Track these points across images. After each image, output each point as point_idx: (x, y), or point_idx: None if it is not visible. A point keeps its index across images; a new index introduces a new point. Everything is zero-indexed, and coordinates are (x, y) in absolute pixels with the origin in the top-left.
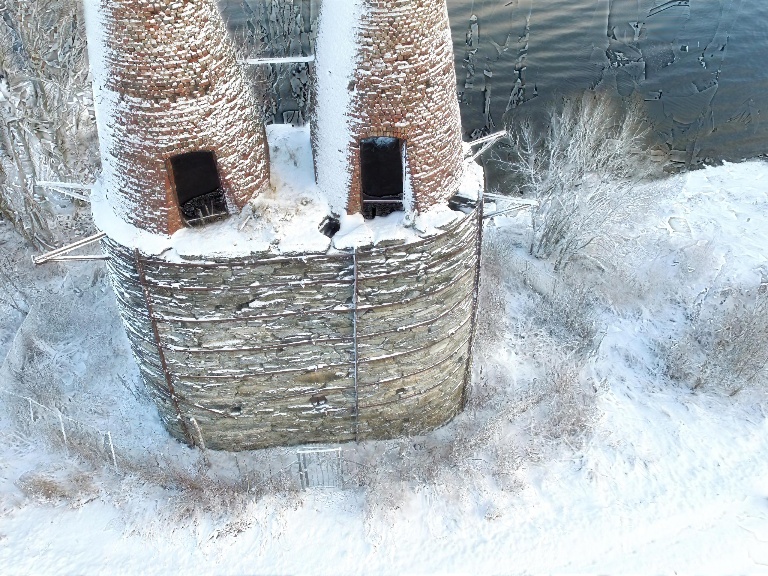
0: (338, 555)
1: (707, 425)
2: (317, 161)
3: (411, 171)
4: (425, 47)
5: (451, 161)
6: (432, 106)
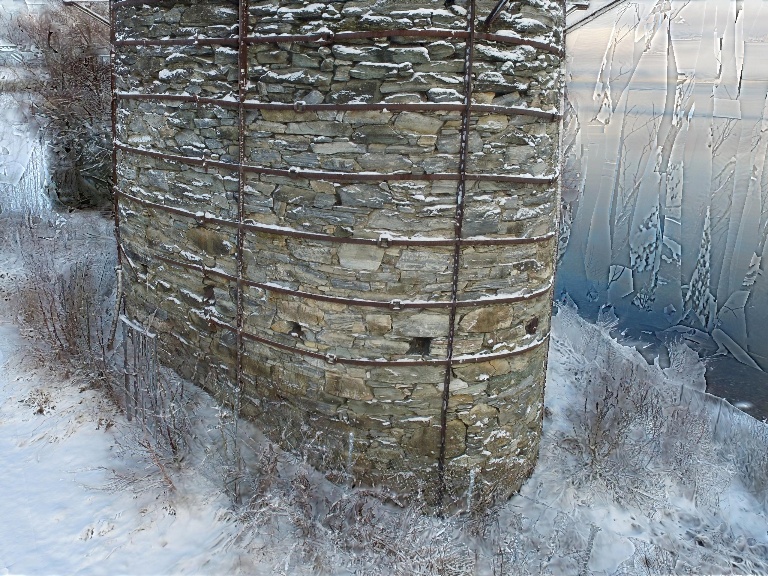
0: (55, 505)
1: None
2: None
3: None
4: None
5: None
6: None
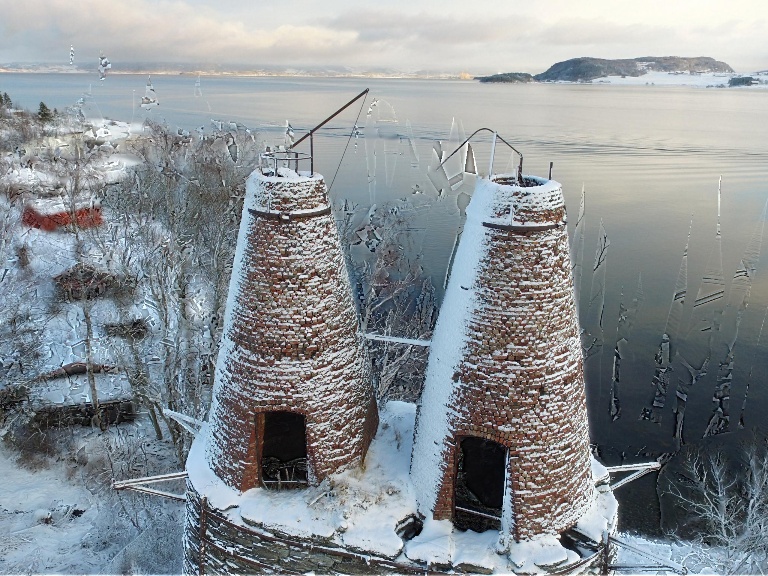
0: None
1: None
2: (414, 449)
3: (512, 485)
4: (542, 351)
5: (568, 485)
6: (546, 416)
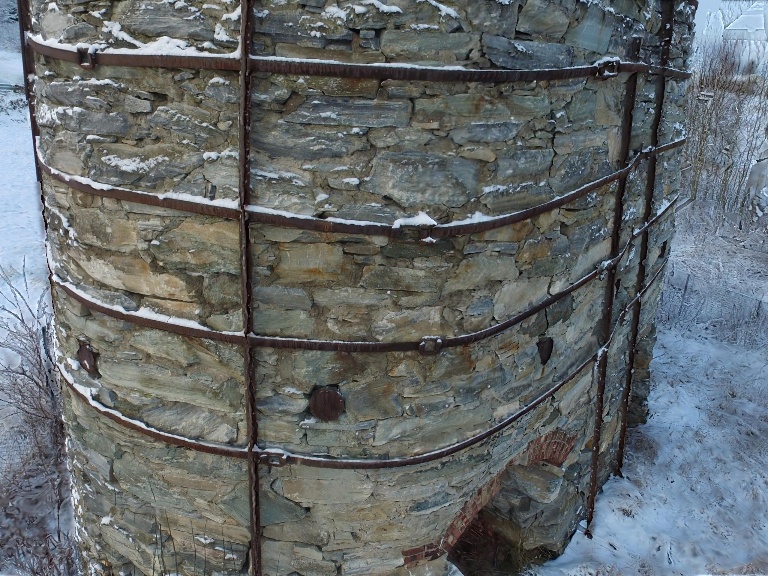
0: None
1: None
2: None
3: None
4: None
5: None
6: None
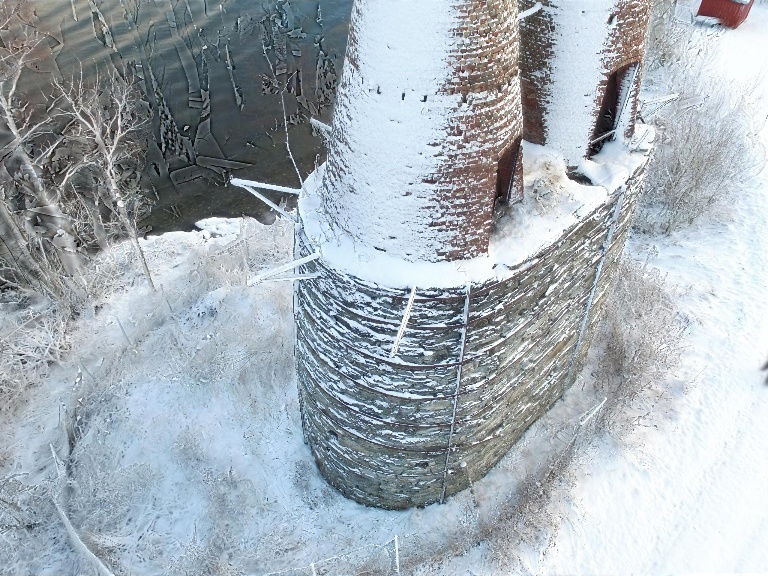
0: (634, 496)
1: (706, 249)
2: (547, 119)
3: (636, 94)
4: None
5: None
6: None
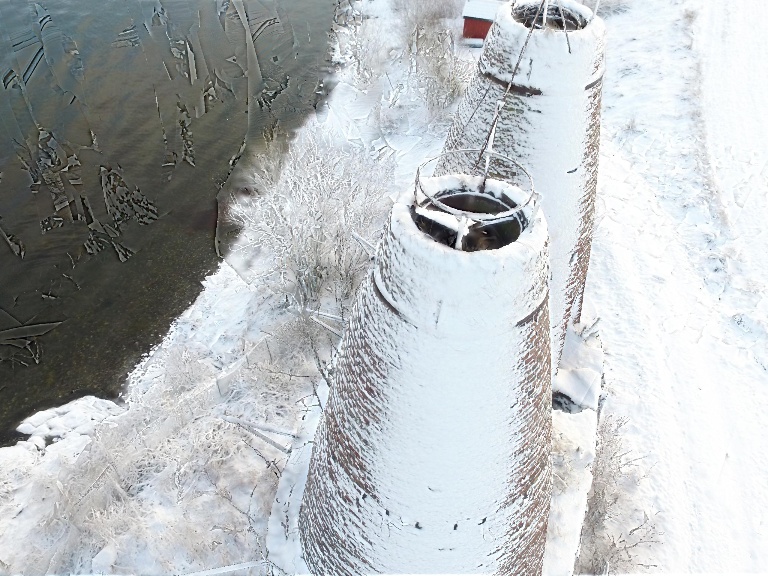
0: None
1: None
2: None
3: None
4: None
5: None
6: None
